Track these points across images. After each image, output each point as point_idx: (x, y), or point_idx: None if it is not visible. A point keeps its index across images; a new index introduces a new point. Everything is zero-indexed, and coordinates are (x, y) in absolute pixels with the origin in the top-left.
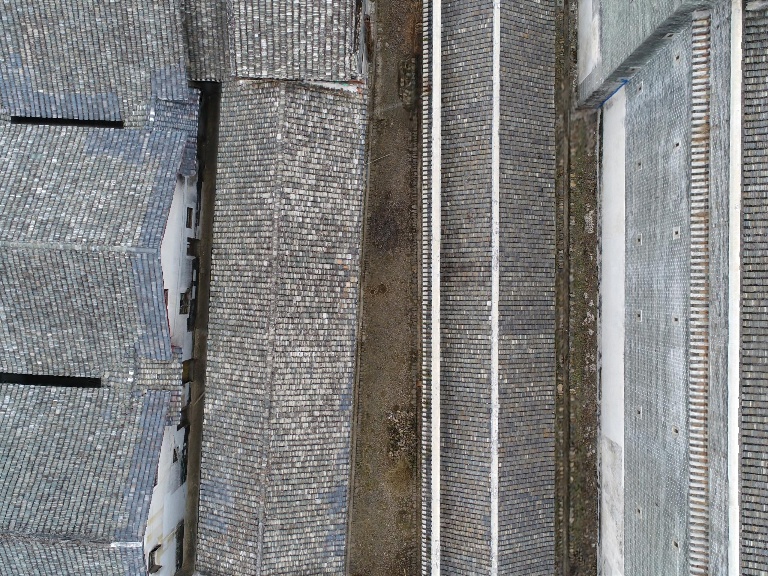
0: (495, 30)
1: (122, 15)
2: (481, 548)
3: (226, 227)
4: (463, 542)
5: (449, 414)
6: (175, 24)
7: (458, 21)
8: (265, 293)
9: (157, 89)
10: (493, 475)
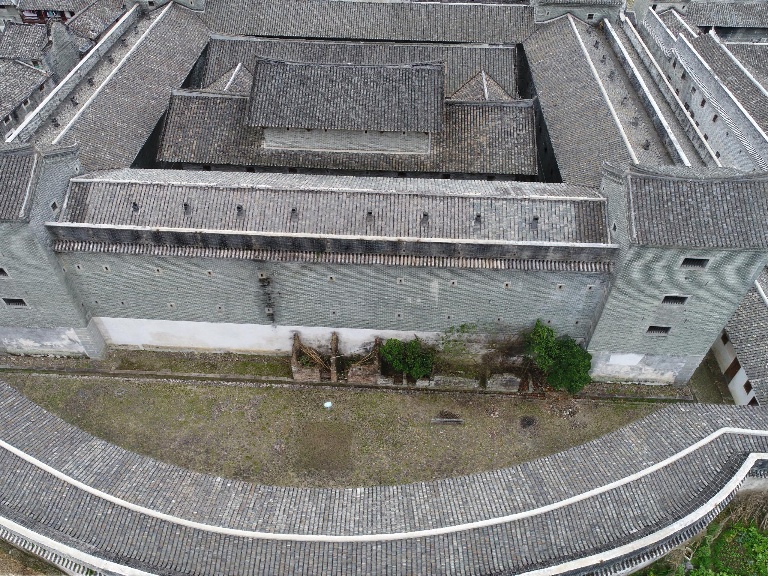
0: None
1: None
2: None
3: None
4: None
5: None
6: None
7: None
8: None
9: None
10: None
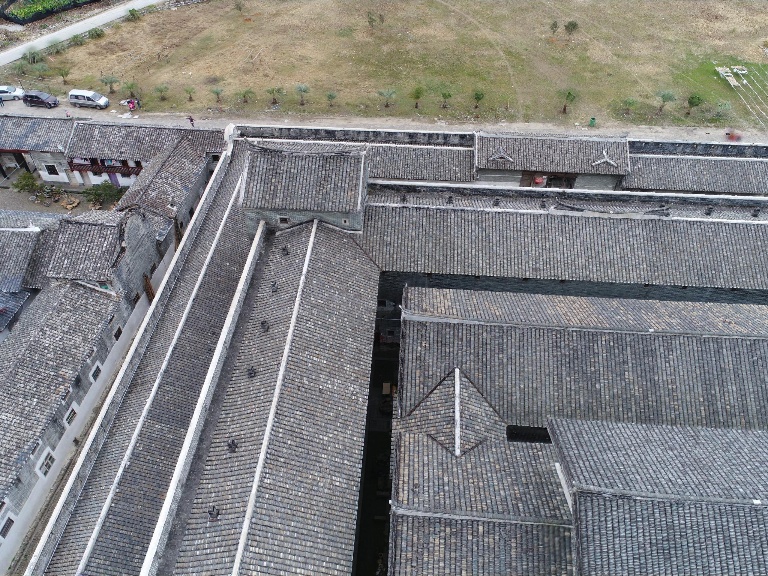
0: (201, 273)
1: (2, 252)
2: (71, 572)
3: (2, 350)
4: (61, 572)
5: (95, 475)
6: (27, 256)
7: (187, 273)
8: (1, 378)
9: (3, 286)
10: (103, 508)
